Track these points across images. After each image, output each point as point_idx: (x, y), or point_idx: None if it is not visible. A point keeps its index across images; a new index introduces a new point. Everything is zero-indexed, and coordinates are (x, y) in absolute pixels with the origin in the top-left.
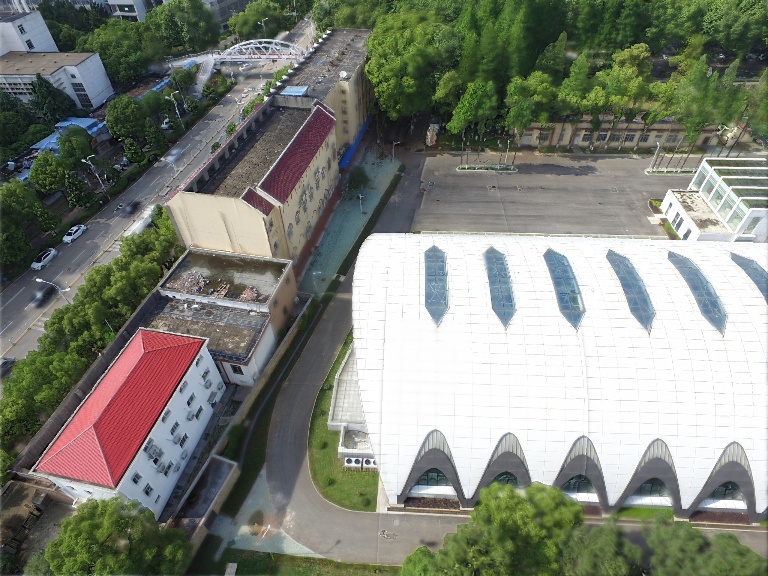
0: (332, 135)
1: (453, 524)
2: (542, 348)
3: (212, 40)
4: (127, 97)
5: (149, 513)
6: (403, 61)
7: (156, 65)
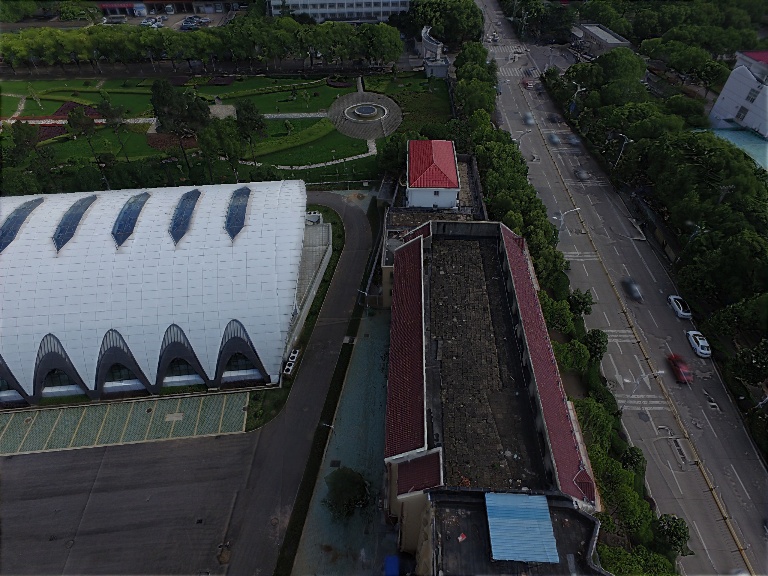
0: None
1: None
2: None
3: None
4: None
5: (394, 148)
6: None
7: None
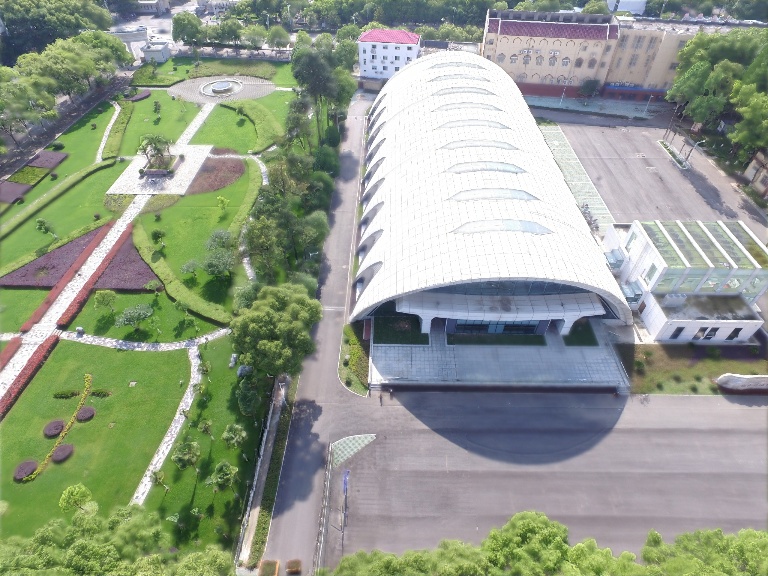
0: (597, 47)
1: (360, 130)
2: (420, 91)
3: (750, 16)
4: (601, 2)
5: (353, 52)
6: (720, 39)
7: (682, 12)
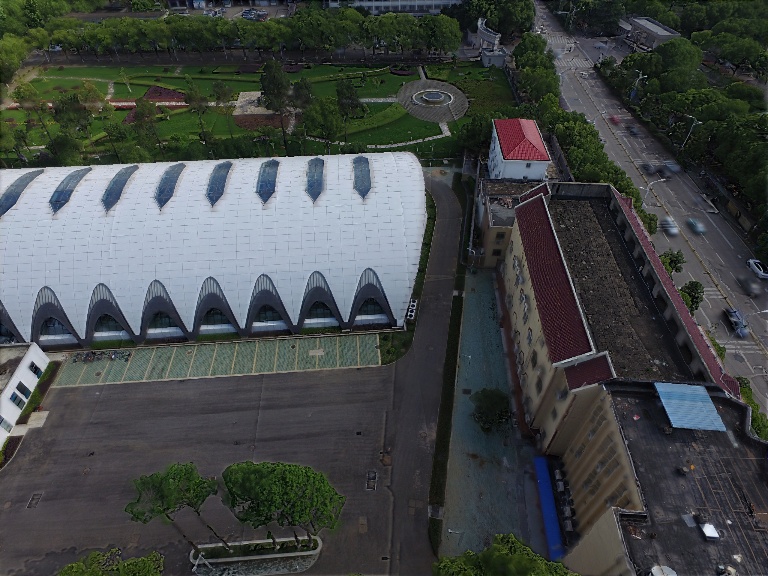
0: None
1: None
2: None
3: None
4: None
5: (478, 127)
6: None
7: None
